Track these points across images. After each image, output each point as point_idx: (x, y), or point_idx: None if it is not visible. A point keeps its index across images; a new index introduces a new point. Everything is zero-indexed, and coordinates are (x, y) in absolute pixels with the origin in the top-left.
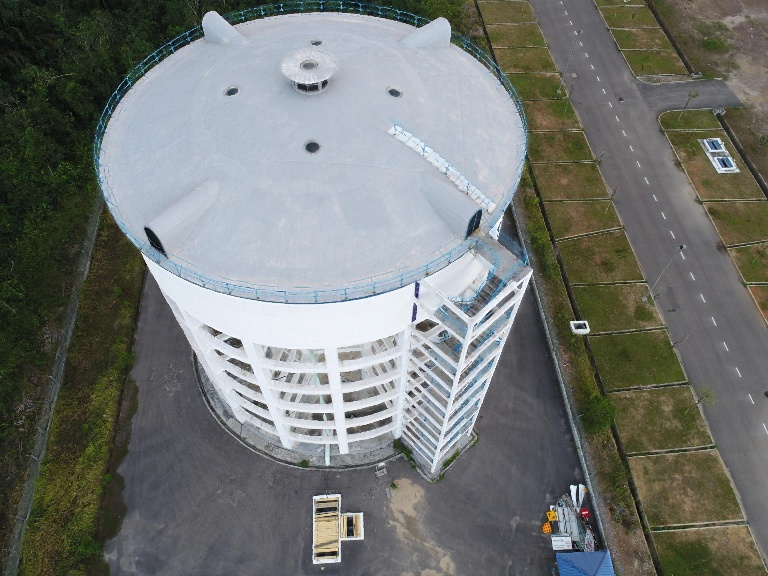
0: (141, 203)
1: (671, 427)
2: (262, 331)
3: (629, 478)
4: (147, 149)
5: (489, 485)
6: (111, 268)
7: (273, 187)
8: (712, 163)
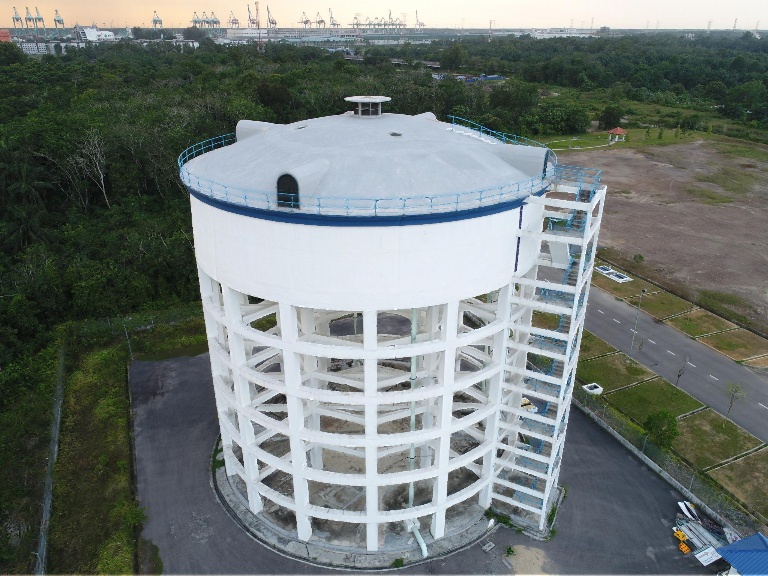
0: (251, 189)
1: (721, 440)
2: (392, 283)
3: (720, 488)
4: (237, 167)
5: (603, 527)
6: (85, 448)
7: (378, 154)
8: (611, 278)
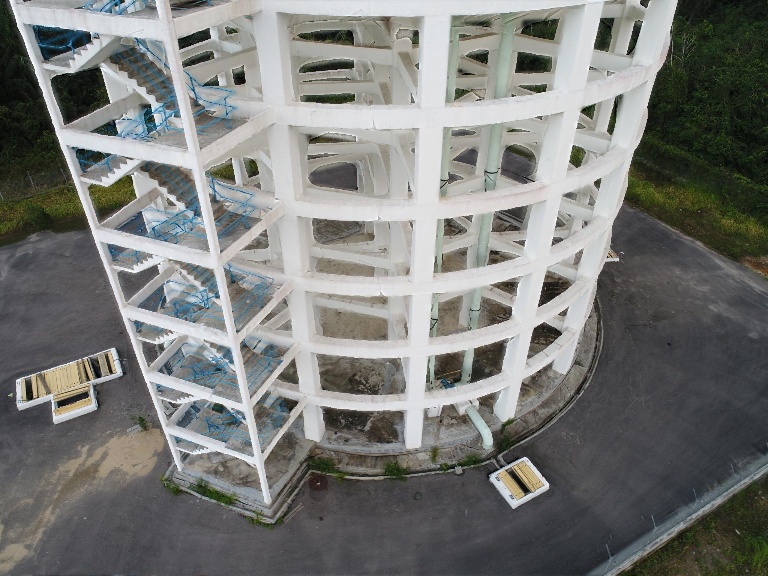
0: None
1: None
2: None
3: None
4: None
5: None
6: None
7: None
8: None
